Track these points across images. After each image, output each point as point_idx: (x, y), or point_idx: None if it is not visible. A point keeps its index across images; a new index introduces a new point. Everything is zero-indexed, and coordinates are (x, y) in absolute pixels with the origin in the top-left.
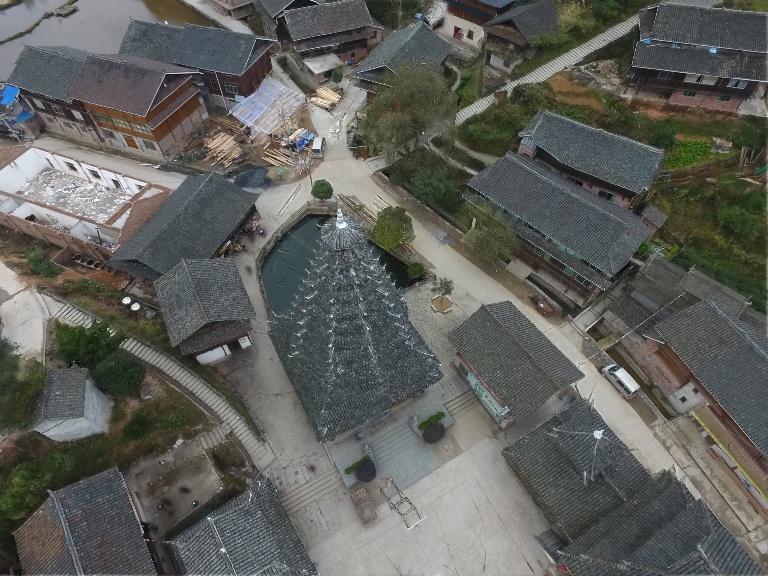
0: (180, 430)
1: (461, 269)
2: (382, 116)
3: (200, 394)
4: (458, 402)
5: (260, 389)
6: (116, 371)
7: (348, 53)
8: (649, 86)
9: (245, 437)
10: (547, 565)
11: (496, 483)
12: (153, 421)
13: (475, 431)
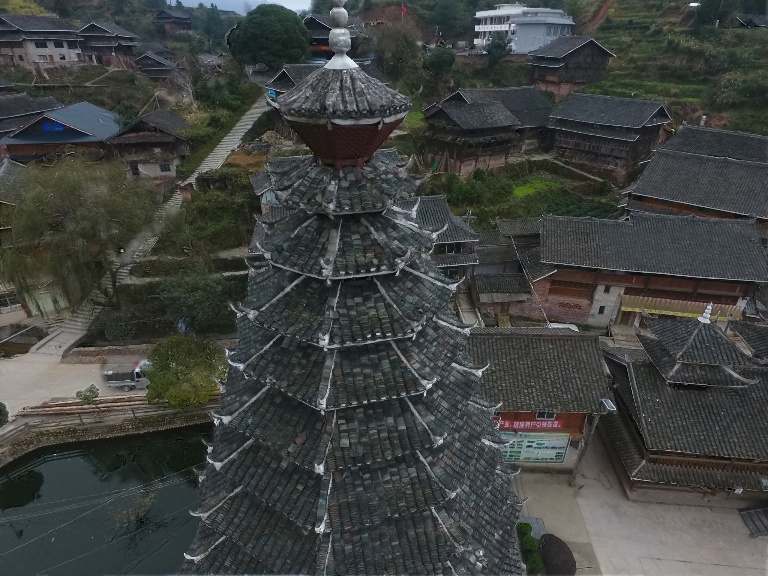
0: None
1: None
2: (46, 231)
3: None
4: None
5: None
6: None
7: None
8: None
9: None
10: None
11: (656, 533)
12: None
13: (561, 506)
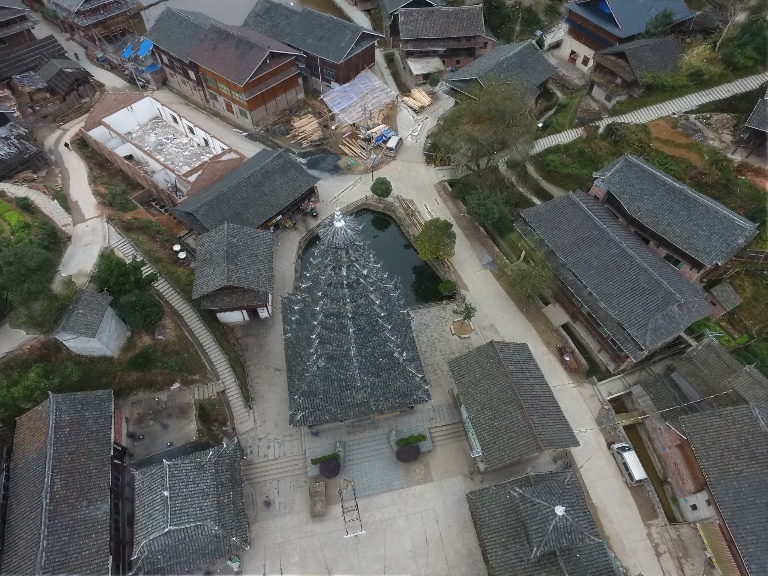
0: (179, 375)
1: (495, 298)
2: (454, 127)
3: (208, 348)
4: (444, 430)
5: (264, 360)
6: (135, 306)
7: (454, 59)
8: (763, 151)
9: (234, 399)
10: None
11: (455, 524)
12: (156, 360)
13: (452, 465)
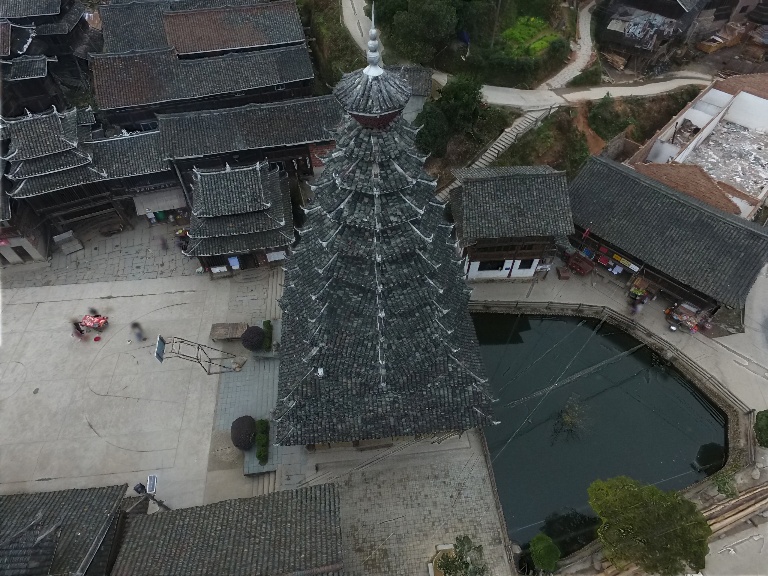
0: None
1: None
2: None
3: None
4: None
5: None
6: (424, 117)
7: None
8: None
9: None
10: None
11: None
12: None
13: None
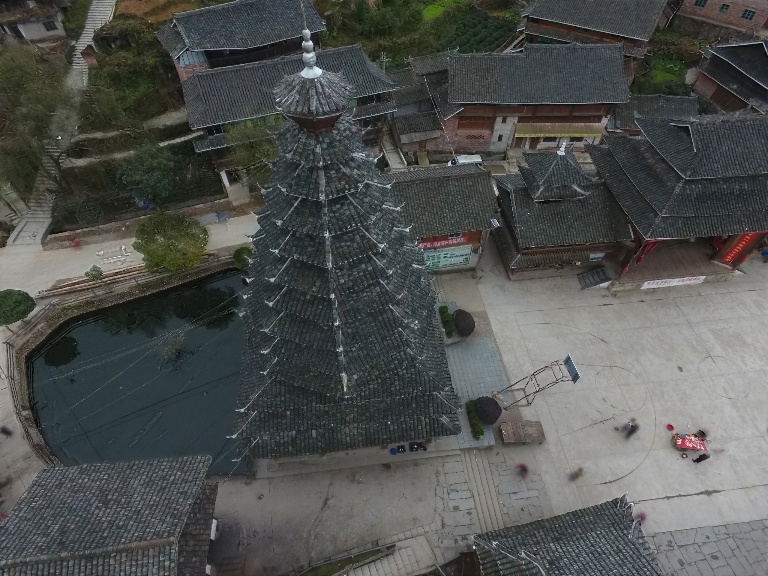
0: None
1: None
2: None
3: None
4: None
5: (301, 531)
6: None
7: None
8: None
9: (379, 575)
10: (607, 292)
11: (526, 297)
12: None
13: (467, 292)
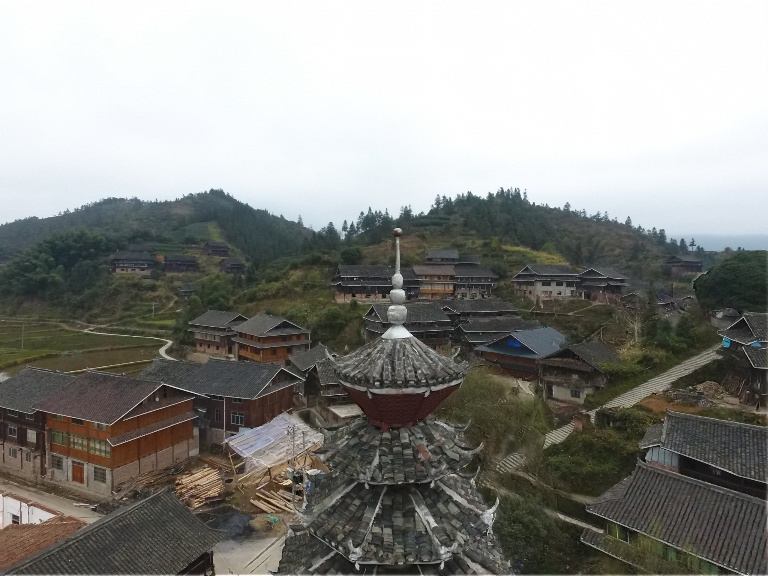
0: None
1: None
2: None
3: None
4: None
5: None
6: None
7: None
8: None
9: None
10: None
11: None
12: None
13: None
